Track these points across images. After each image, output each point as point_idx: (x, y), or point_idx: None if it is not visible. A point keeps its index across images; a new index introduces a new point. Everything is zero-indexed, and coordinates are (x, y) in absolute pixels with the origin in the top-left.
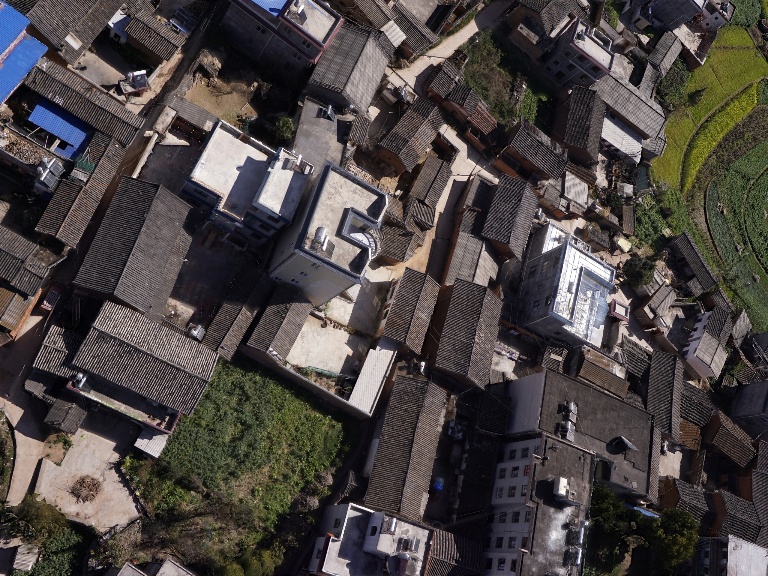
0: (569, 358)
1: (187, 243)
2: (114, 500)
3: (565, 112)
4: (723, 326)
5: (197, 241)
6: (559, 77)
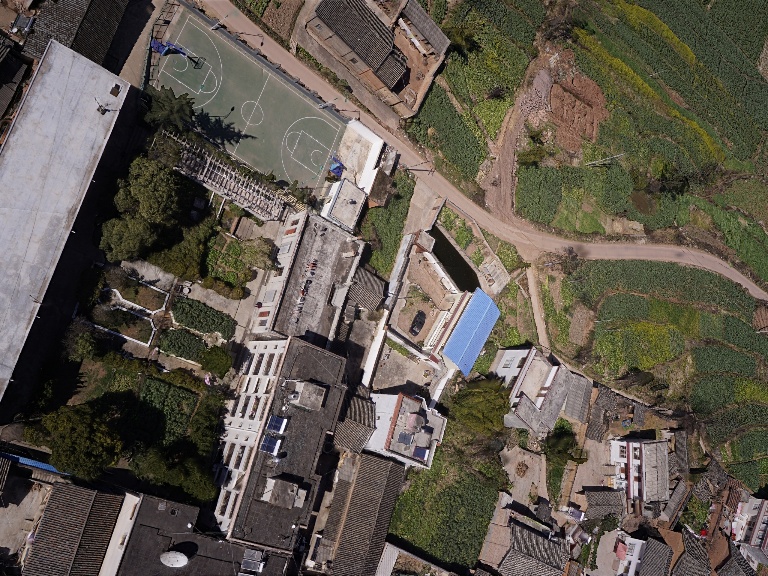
0: None
1: None
2: (510, 463)
3: None
4: None
5: None
6: None
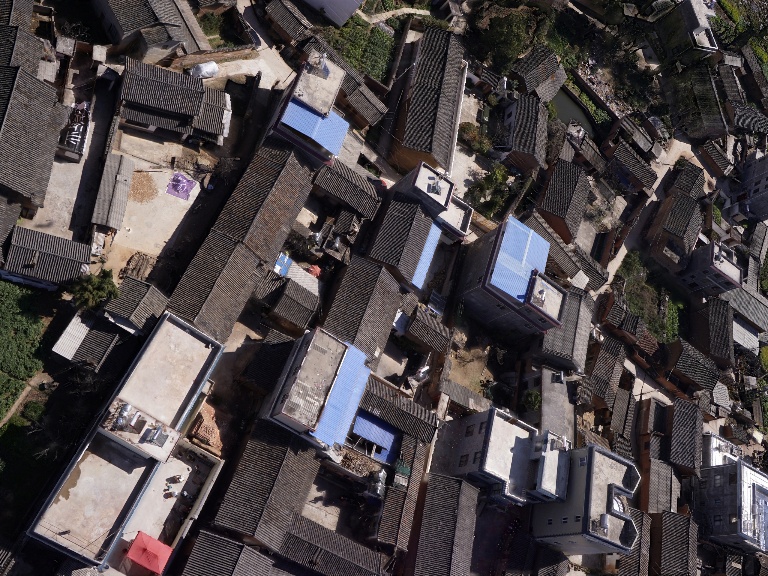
0: (744, 563)
1: (474, 521)
2: None
3: (703, 321)
4: None
5: None
6: (692, 286)
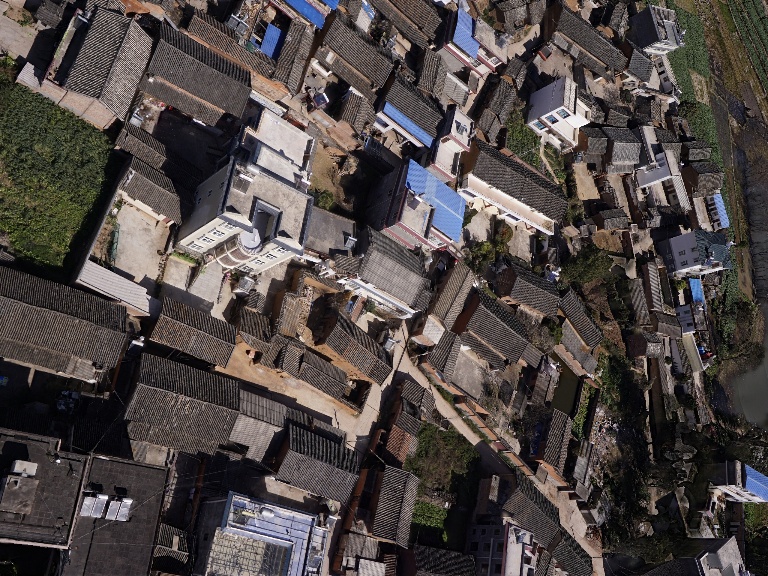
0: (177, 569)
1: (210, 121)
2: None
3: None
4: None
5: (211, 144)
6: (472, 548)
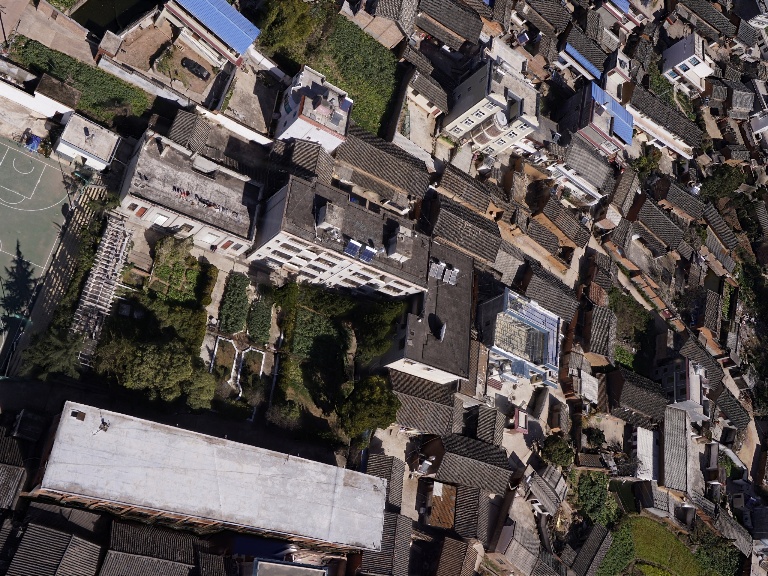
0: None
1: (455, 47)
2: None
3: None
4: (553, 569)
5: (453, 66)
6: None
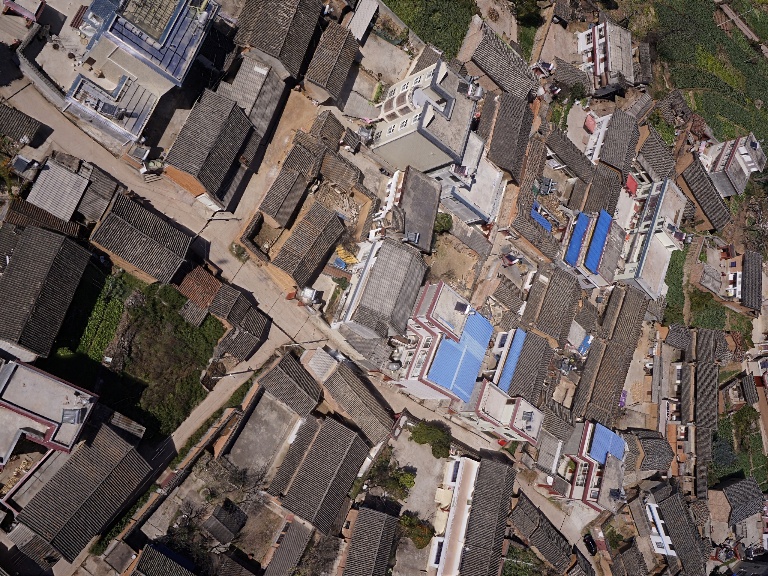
0: None
1: None
2: (482, 4)
3: None
4: None
5: None
6: None
